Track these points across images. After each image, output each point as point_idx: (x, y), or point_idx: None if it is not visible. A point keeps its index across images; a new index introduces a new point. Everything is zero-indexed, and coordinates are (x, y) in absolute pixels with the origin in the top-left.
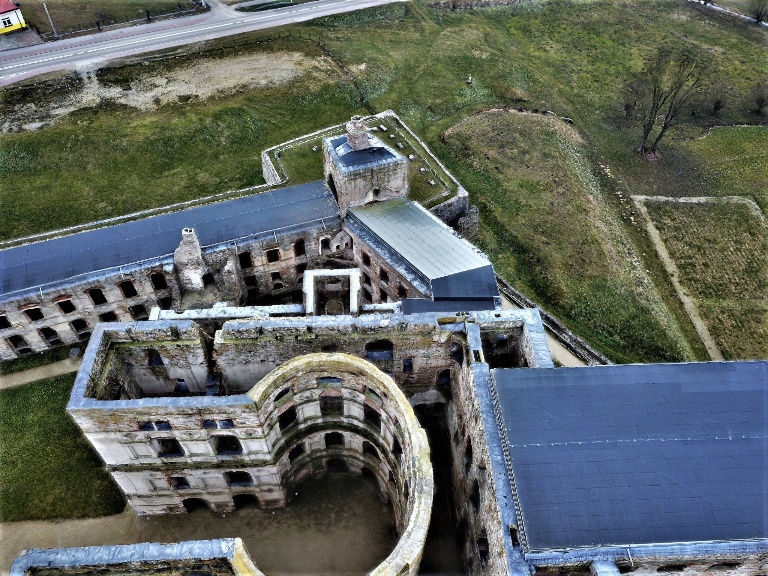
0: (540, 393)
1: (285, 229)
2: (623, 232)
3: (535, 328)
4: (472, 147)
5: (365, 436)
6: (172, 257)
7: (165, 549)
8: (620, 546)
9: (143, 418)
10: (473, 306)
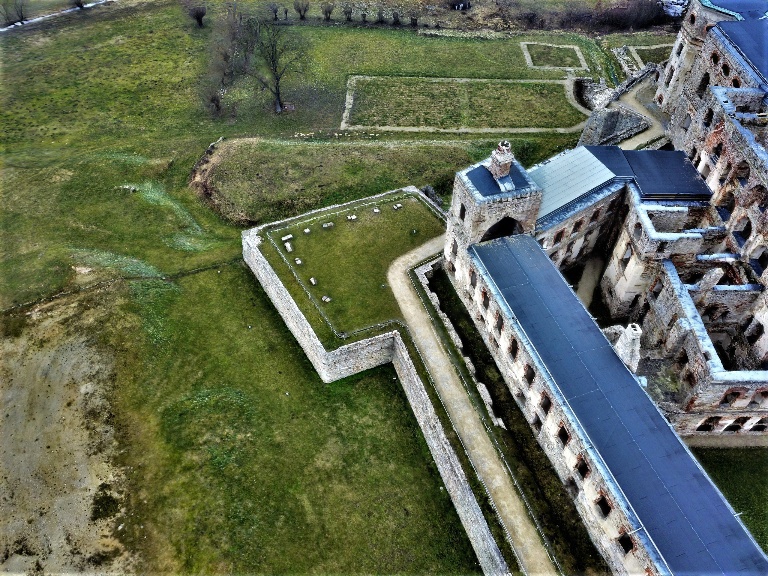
0: None
1: None
2: (392, 141)
3: (729, 89)
4: (281, 198)
5: None
6: None
7: None
8: None
9: None
10: (632, 160)
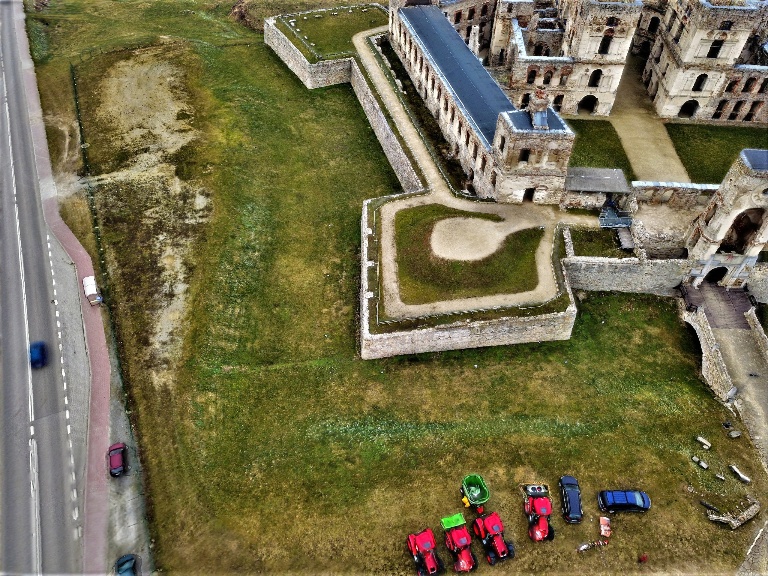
0: None
1: None
2: None
3: None
4: None
5: None
6: None
7: None
8: None
9: None
10: None
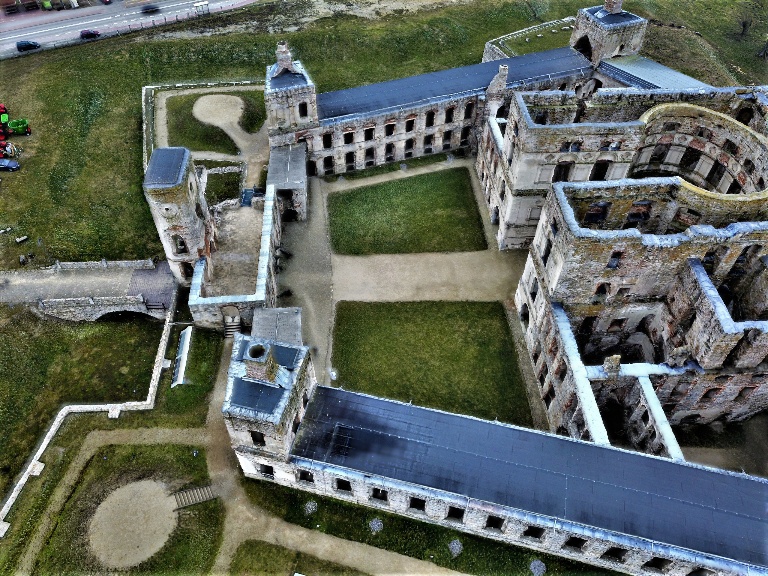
0: None
1: (556, 74)
2: None
3: None
4: None
5: None
6: (483, 90)
7: (638, 180)
8: None
9: (569, 138)
10: None
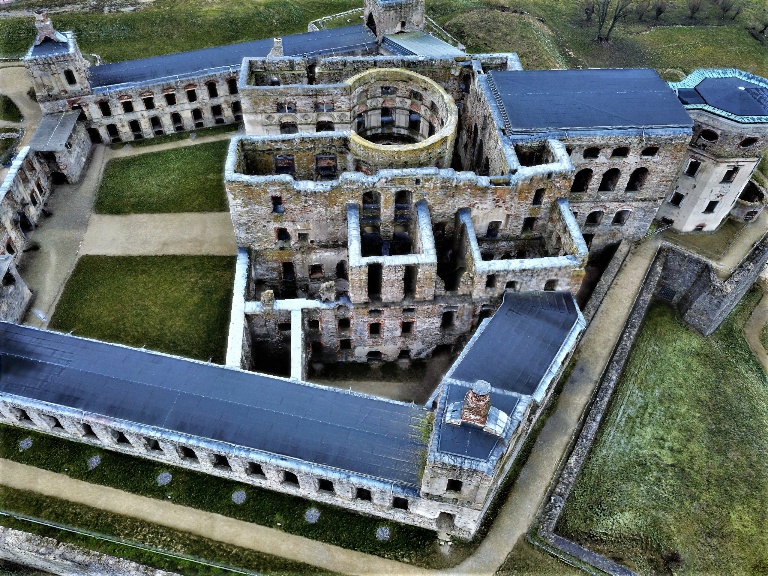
0: (518, 78)
1: (340, 49)
2: None
3: (515, 60)
4: (466, 31)
5: (408, 141)
6: None
7: (313, 133)
8: (561, 128)
9: (282, 99)
10: None
